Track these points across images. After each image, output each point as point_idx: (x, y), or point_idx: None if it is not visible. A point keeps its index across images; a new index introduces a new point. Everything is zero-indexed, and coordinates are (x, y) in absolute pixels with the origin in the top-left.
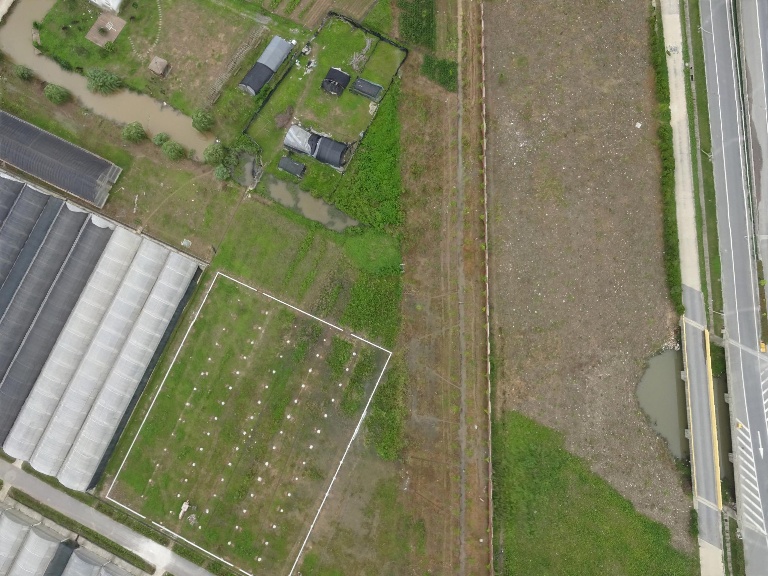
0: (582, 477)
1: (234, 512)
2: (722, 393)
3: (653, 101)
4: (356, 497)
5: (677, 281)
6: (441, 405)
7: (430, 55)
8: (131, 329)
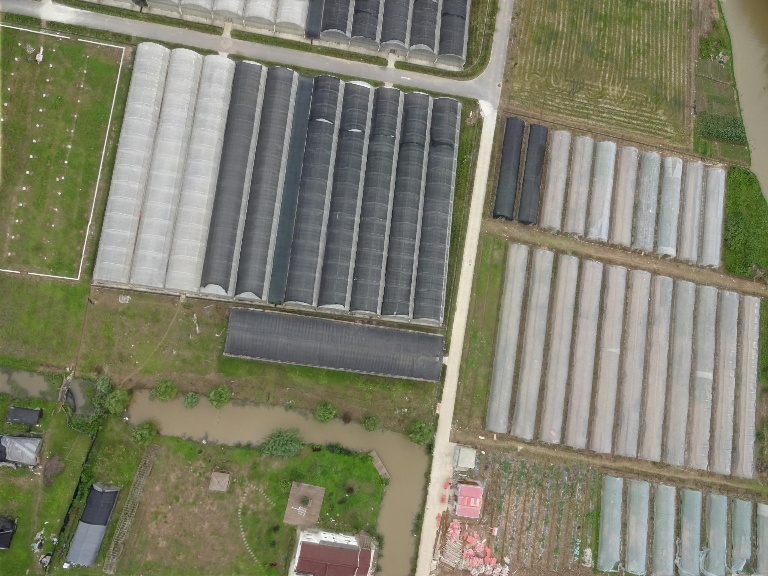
0: None
1: None
2: None
3: None
4: None
5: None
6: None
7: None
8: (144, 197)
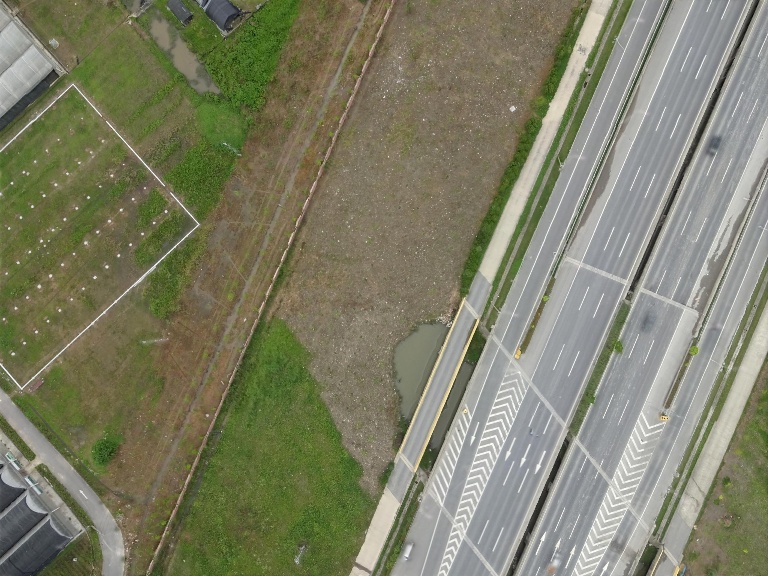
0: (310, 397)
1: (6, 305)
2: (468, 379)
3: (538, 91)
4: (117, 336)
5: (473, 266)
6: (223, 288)
7: None
8: None
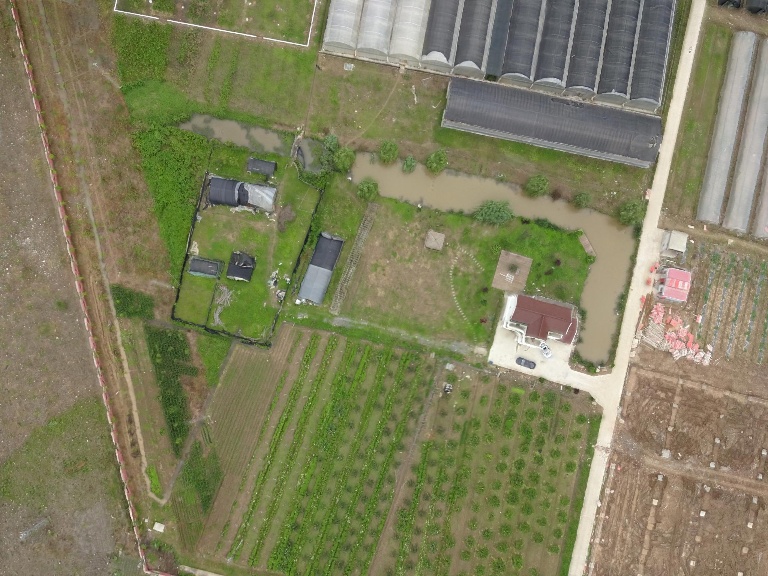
0: None
1: None
2: None
3: None
4: None
5: None
6: None
7: (148, 320)
8: None
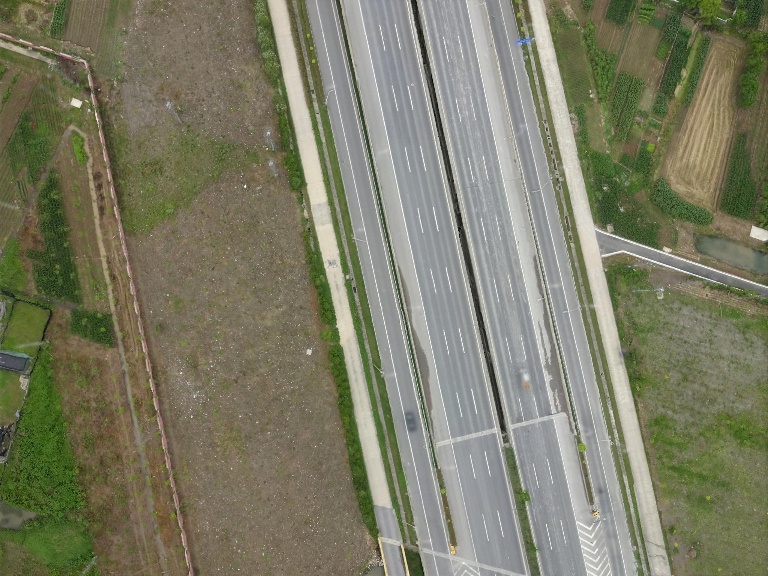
0: None
1: None
2: None
3: (320, 323)
4: None
5: (367, 509)
6: None
7: (78, 309)
8: None
